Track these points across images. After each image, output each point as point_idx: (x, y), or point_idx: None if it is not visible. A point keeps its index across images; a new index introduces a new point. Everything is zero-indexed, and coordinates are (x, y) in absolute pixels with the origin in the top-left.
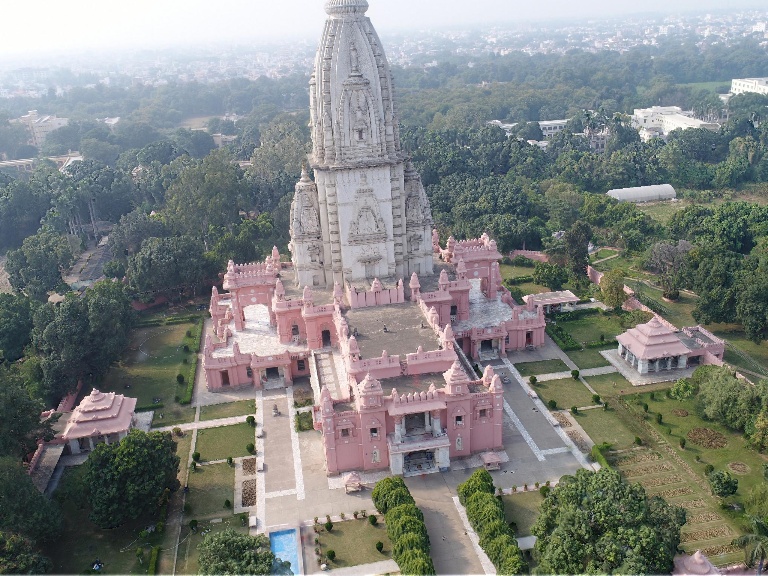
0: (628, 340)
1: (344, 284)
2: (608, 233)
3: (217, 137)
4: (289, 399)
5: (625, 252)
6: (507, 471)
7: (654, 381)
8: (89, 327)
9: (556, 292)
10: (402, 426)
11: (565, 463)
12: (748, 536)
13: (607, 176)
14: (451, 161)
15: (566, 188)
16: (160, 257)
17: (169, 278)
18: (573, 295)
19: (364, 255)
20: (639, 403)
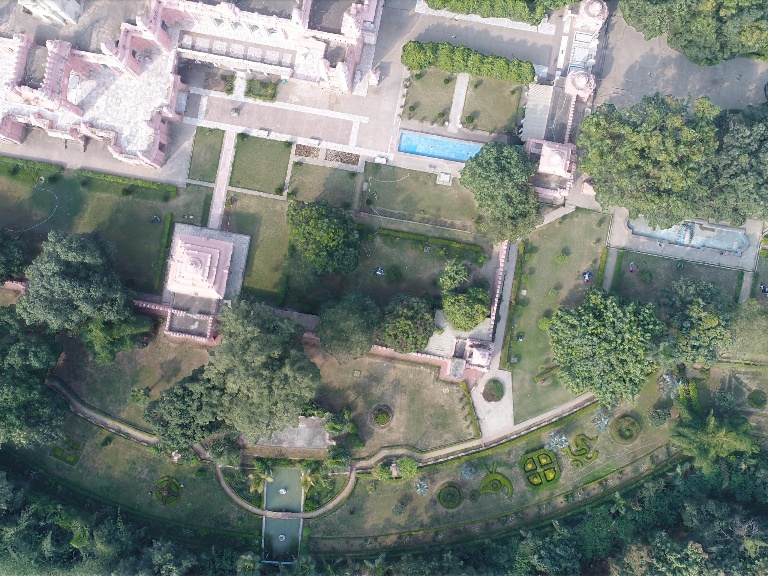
0: None
1: None
2: None
3: None
4: (214, 95)
5: None
6: None
7: None
8: (90, 265)
9: None
10: None
11: None
12: None
13: None
14: None
15: None
16: None
17: None
18: None
19: None
20: None
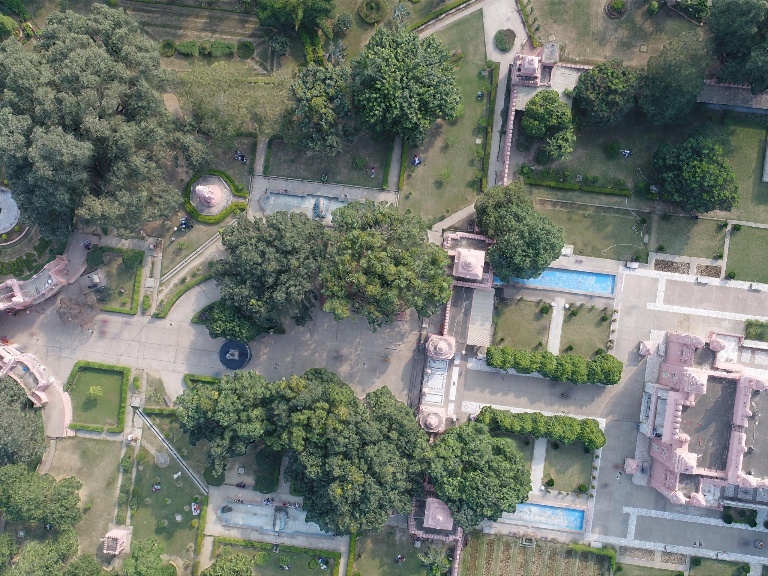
0: None
1: None
2: None
3: None
4: None
5: None
6: (621, 474)
7: None
8: None
9: None
10: None
11: (613, 524)
12: (439, 556)
13: None
14: None
15: None
16: None
17: None
18: None
19: None
20: None
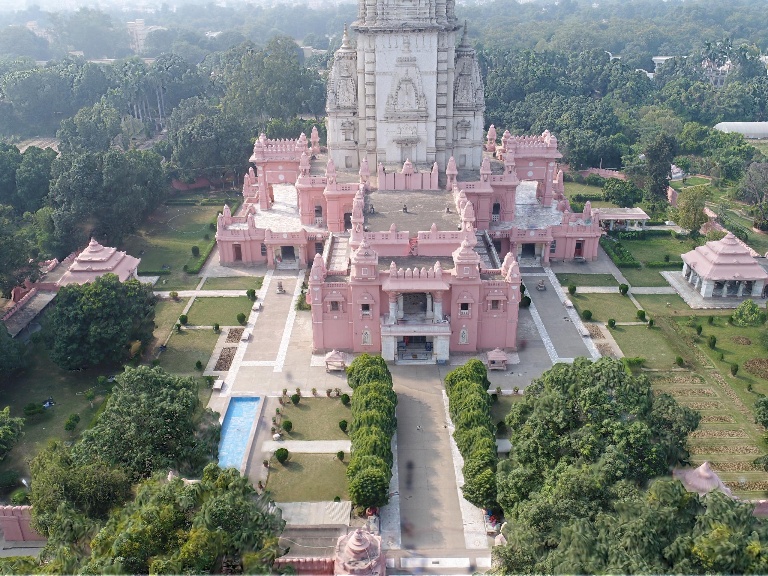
0: (694, 258)
1: (377, 167)
2: (703, 159)
3: (307, 50)
4: (299, 280)
5: (719, 181)
6: (514, 373)
7: (718, 306)
8: (103, 182)
9: (624, 208)
10: (399, 307)
11: None
12: None
13: (718, 108)
14: (540, 77)
15: (666, 114)
16: (201, 133)
17: (210, 158)
18: (643, 212)
19: (401, 135)
20: (692, 325)
